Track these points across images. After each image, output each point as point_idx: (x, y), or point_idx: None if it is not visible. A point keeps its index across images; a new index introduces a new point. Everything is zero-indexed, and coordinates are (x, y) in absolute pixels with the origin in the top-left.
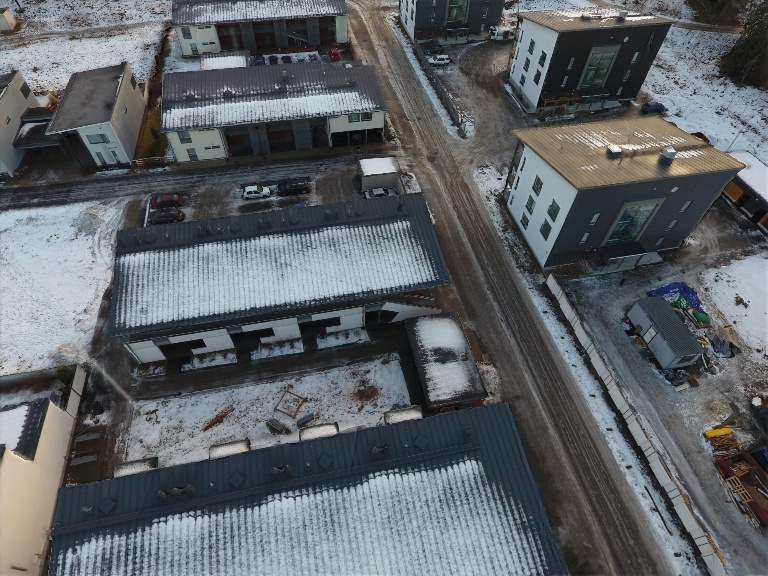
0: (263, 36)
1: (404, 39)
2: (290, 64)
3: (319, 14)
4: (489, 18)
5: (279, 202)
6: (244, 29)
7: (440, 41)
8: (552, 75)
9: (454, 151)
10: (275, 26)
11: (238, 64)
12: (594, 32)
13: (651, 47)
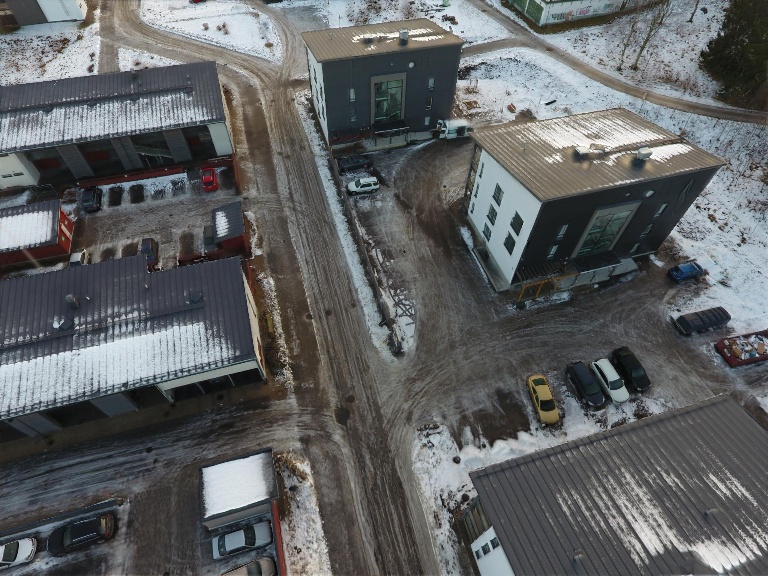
0: (104, 151)
1: (317, 141)
2: (89, 267)
3: (179, 124)
4: (435, 109)
5: (49, 575)
6: (65, 152)
7: (367, 146)
8: (533, 248)
9: (381, 391)
10: (114, 144)
11: (38, 229)
12: (600, 193)
13: (686, 196)
